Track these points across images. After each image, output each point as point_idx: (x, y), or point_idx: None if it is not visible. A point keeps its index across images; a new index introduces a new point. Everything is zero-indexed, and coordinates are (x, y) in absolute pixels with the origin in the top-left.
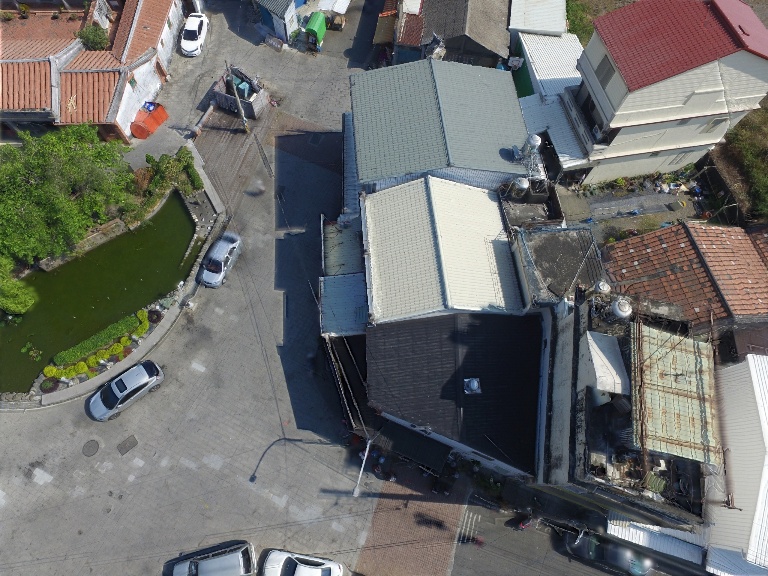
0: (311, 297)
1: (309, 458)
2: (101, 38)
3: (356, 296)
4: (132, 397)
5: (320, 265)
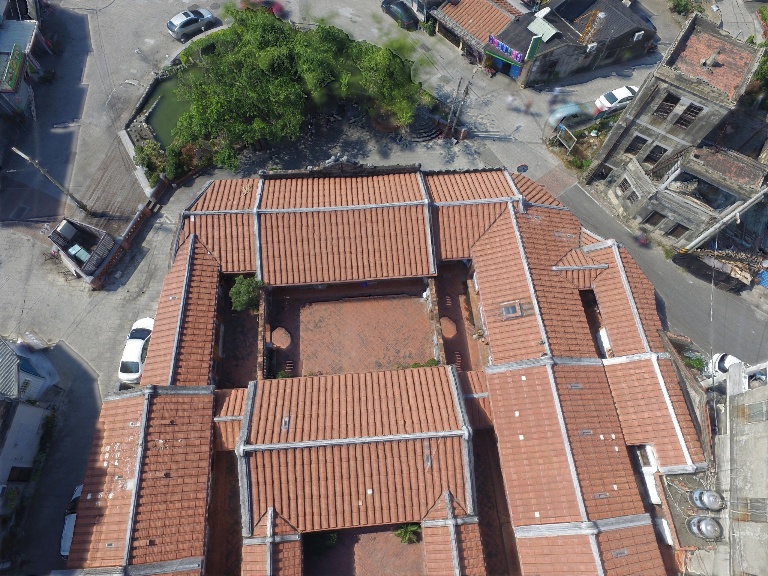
0: (61, 80)
1: (83, 3)
2: None
3: (2, 38)
4: None
5: (48, 101)
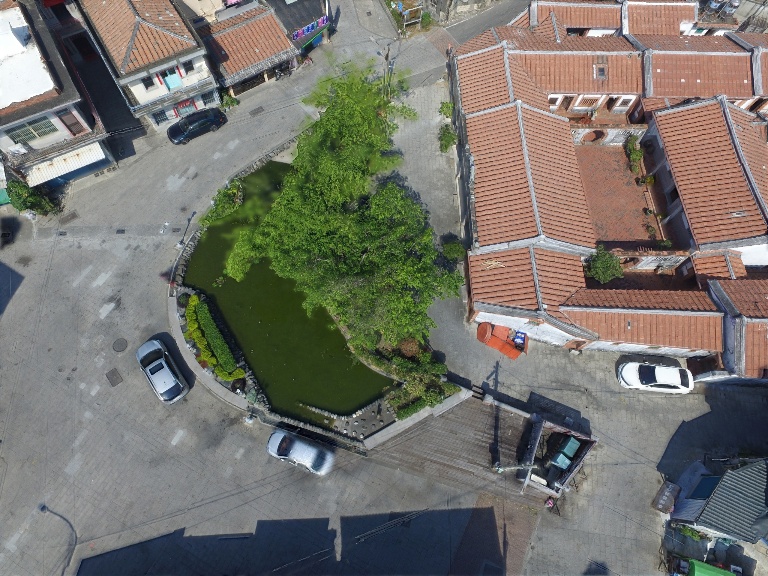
0: (242, 572)
1: (46, 575)
2: (604, 274)
3: None
4: (148, 379)
5: None
